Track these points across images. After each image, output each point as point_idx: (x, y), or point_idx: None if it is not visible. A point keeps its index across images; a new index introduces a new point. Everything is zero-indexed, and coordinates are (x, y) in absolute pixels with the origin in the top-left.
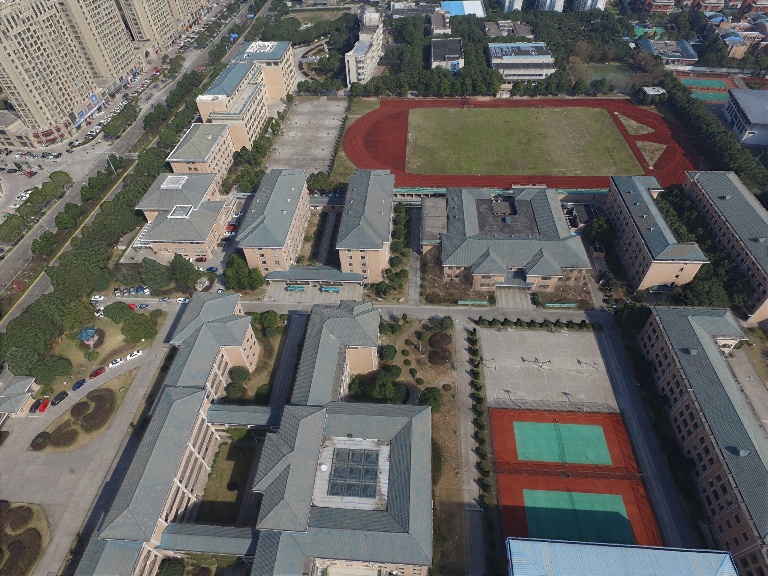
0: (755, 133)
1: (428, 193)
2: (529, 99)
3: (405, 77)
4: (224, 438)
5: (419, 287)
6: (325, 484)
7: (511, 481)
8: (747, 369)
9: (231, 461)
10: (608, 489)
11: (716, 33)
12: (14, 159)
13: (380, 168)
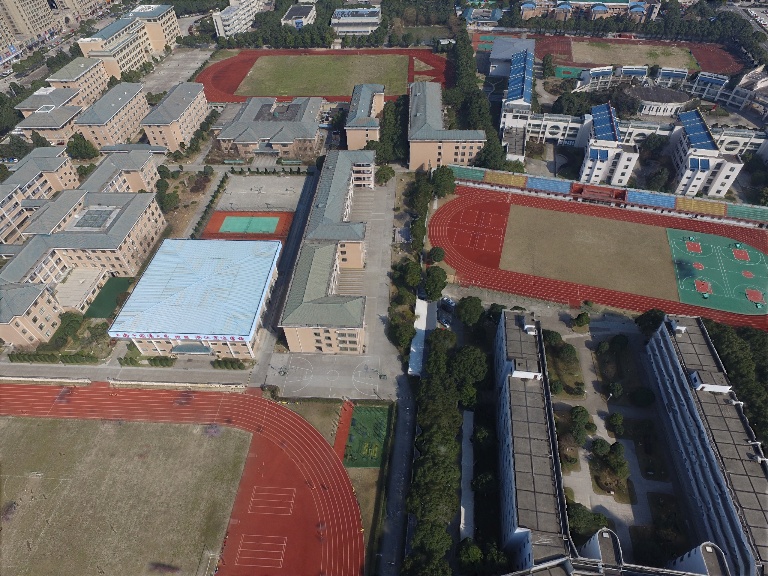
0: (496, 67)
1: None
2: (355, 49)
3: (260, 33)
4: None
5: (205, 156)
6: (75, 223)
7: None
8: (391, 191)
9: None
10: None
11: (519, 2)
12: None
13: (216, 92)
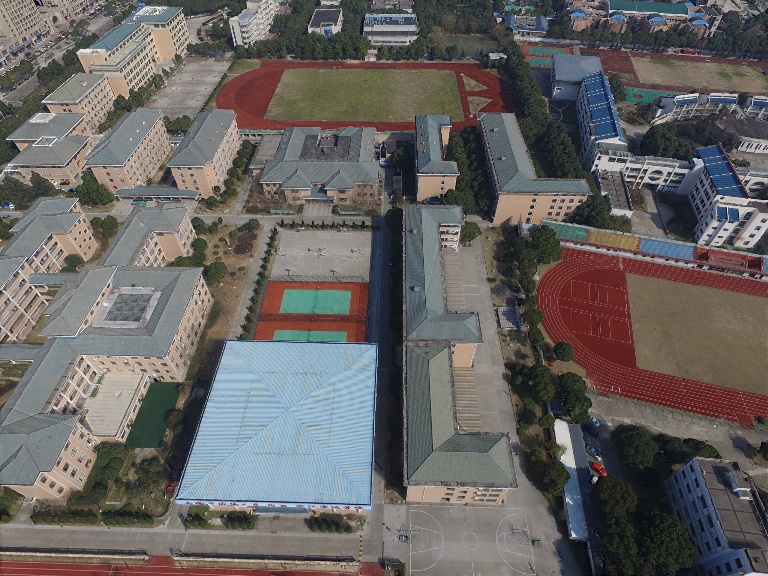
0: (562, 89)
1: (274, 133)
2: (393, 62)
3: (284, 41)
4: None
5: (244, 202)
6: (104, 314)
7: (268, 325)
8: (478, 254)
9: None
10: (339, 328)
11: (567, 10)
12: None
13: (243, 115)
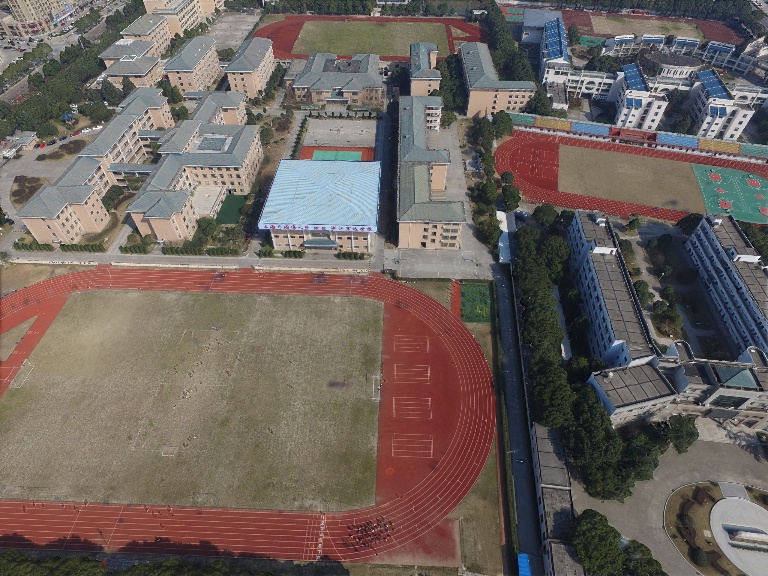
0: (529, 34)
1: None
2: (394, 17)
3: None
4: (149, 156)
5: (281, 103)
6: (196, 147)
7: None
8: (454, 133)
9: (153, 163)
10: None
11: None
12: (7, 42)
13: (274, 51)
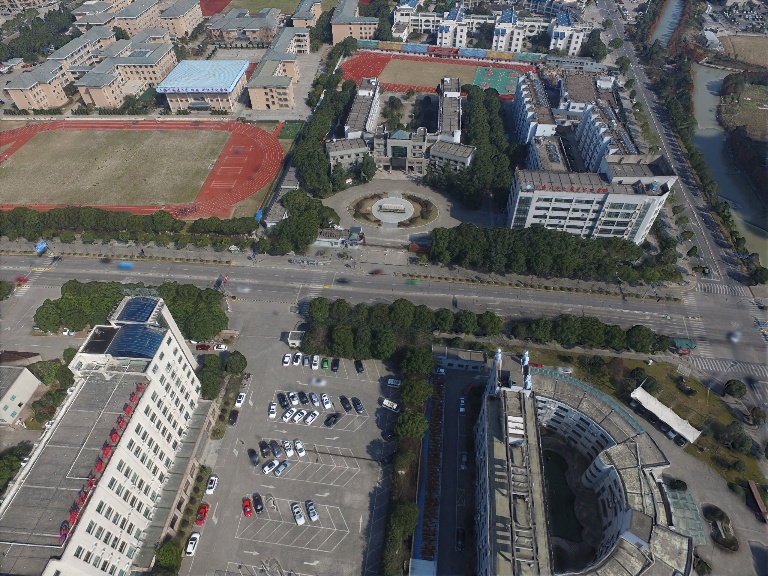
0: None
1: None
2: None
3: None
4: None
5: None
6: None
7: None
8: None
9: None
10: None
11: None
12: (7, 12)
13: (207, 12)
